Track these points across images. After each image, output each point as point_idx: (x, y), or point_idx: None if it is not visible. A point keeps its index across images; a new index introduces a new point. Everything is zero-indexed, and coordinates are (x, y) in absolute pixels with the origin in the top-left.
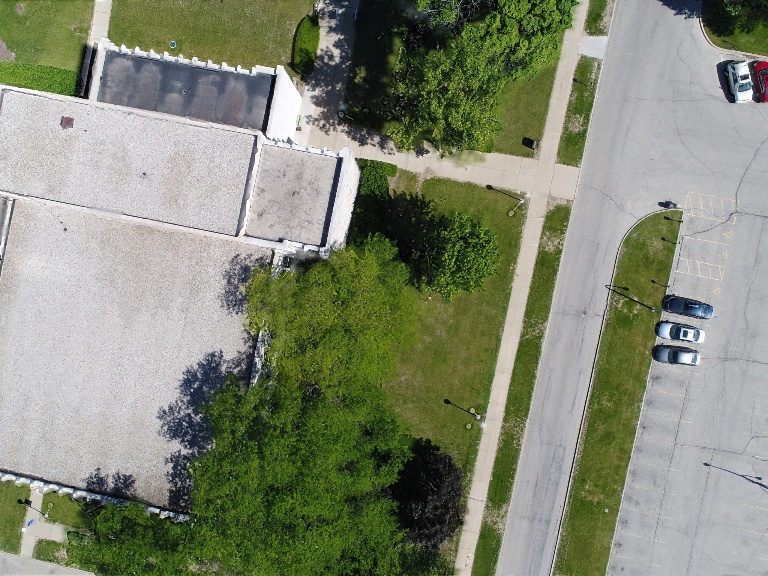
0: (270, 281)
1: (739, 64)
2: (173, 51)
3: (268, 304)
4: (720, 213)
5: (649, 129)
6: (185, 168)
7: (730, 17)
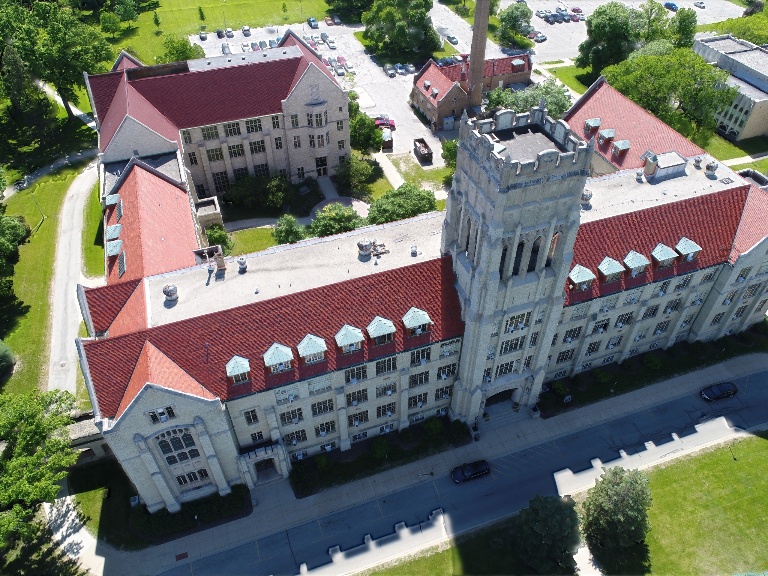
0: (758, 30)
1: (539, 36)
2: (717, 139)
3: (765, 27)
4: None
5: (575, 47)
6: (760, 63)
7: None
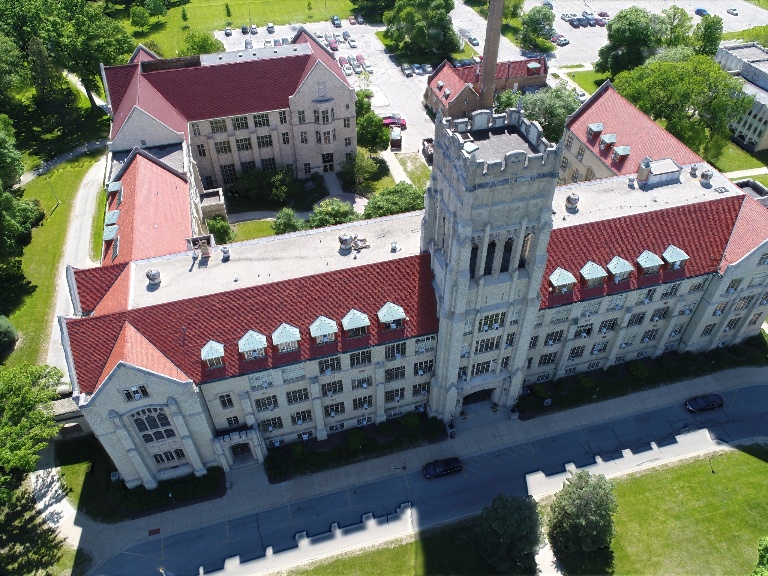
0: None
1: (561, 39)
2: (734, 149)
3: None
4: (604, 38)
5: None
6: None
7: (545, 48)
